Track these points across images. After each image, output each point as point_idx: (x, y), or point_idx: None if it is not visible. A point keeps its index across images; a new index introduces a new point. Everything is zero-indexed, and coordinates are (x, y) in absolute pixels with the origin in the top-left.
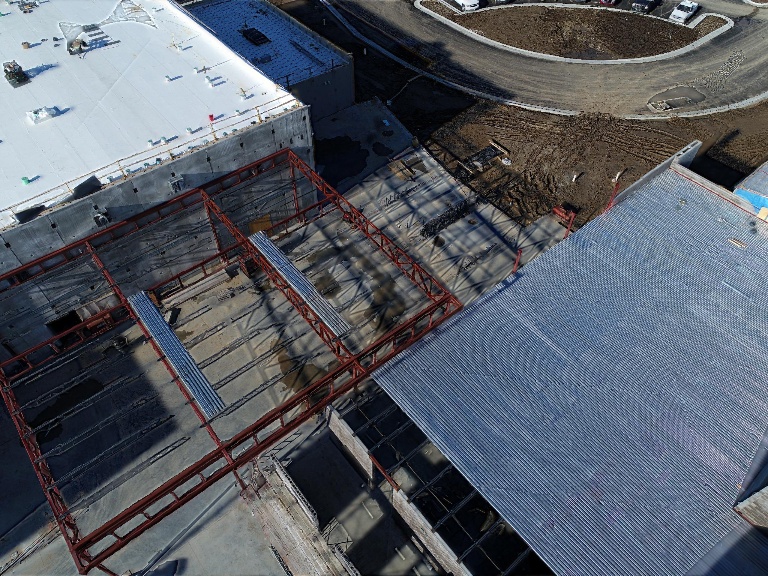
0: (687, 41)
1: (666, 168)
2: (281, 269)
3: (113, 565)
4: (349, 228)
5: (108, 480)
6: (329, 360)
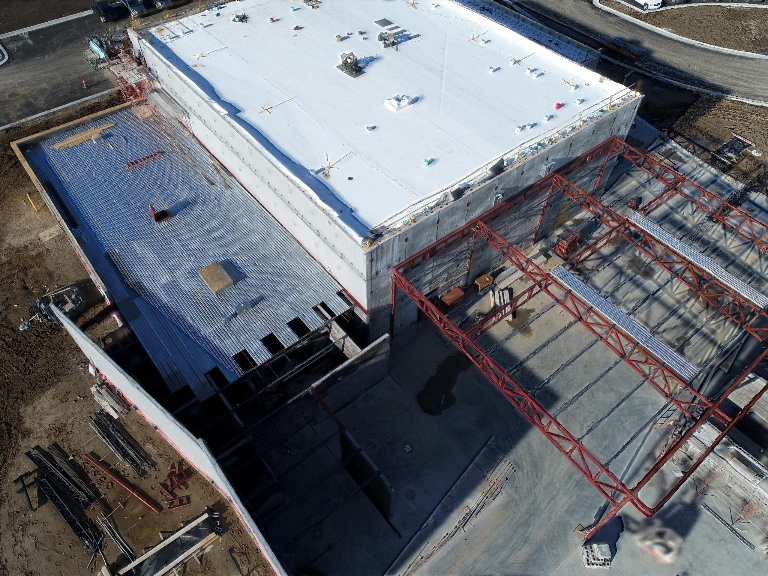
0: None
1: None
2: (676, 247)
3: (563, 520)
4: None
5: (521, 443)
6: (675, 336)
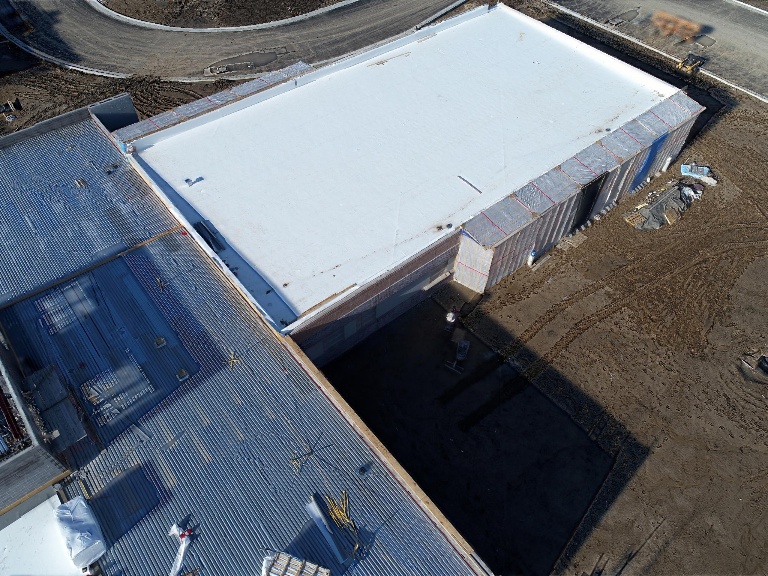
0: (303, 12)
1: (85, 118)
2: None
3: None
4: None
5: None
6: None
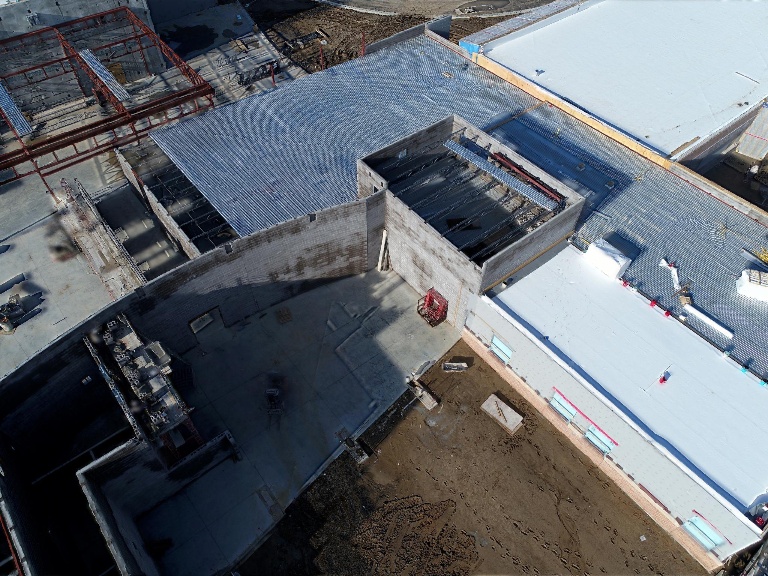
0: None
1: (421, 33)
2: (95, 68)
3: None
4: (186, 79)
5: None
6: None
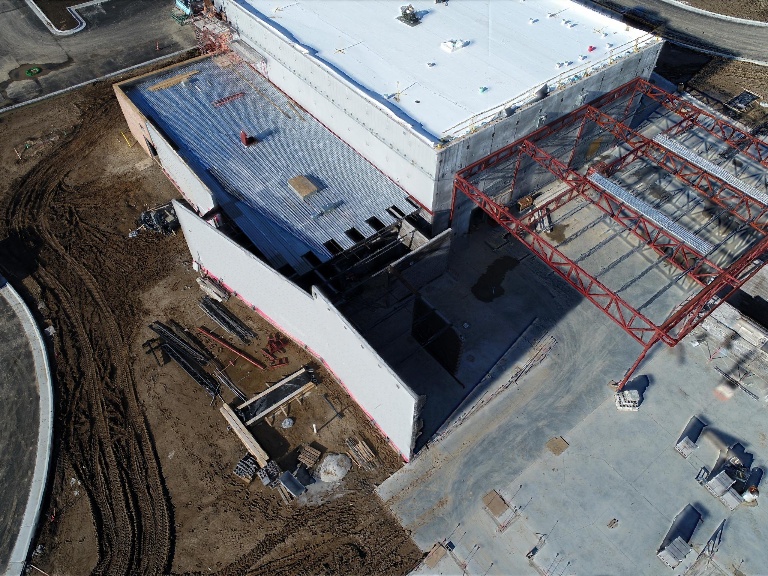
0: None
1: None
2: (693, 160)
3: (598, 377)
4: None
5: (561, 323)
6: None
